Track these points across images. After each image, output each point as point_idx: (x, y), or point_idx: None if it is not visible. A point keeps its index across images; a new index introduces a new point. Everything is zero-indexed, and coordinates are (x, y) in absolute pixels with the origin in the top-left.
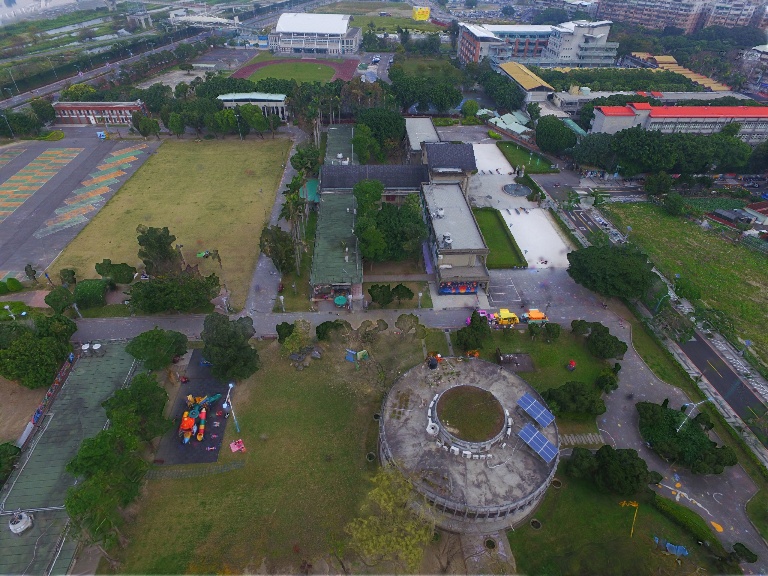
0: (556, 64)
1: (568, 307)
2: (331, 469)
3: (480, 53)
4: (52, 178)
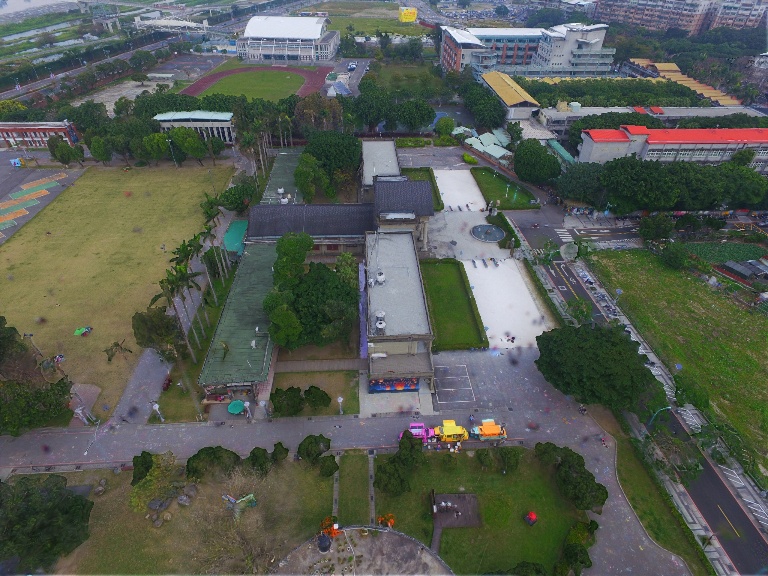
0: (546, 72)
1: (535, 412)
2: None
3: (462, 61)
4: None
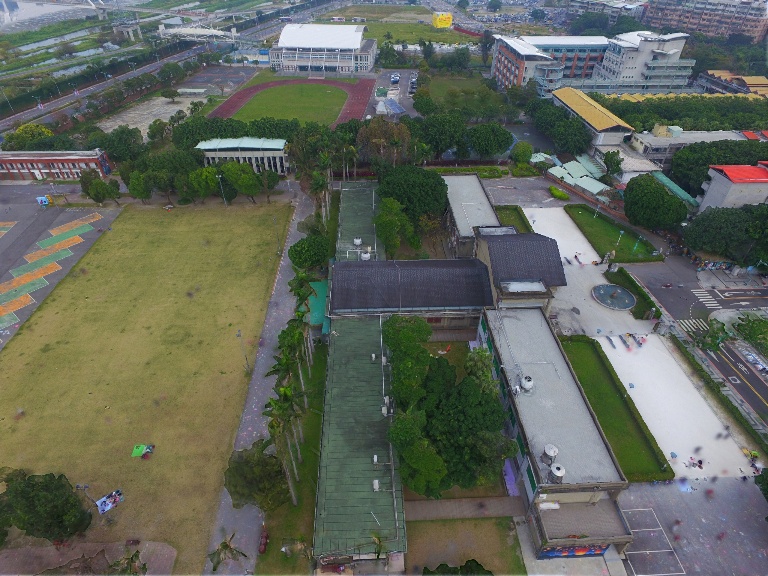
0: (616, 86)
1: None
2: None
3: (524, 74)
4: None
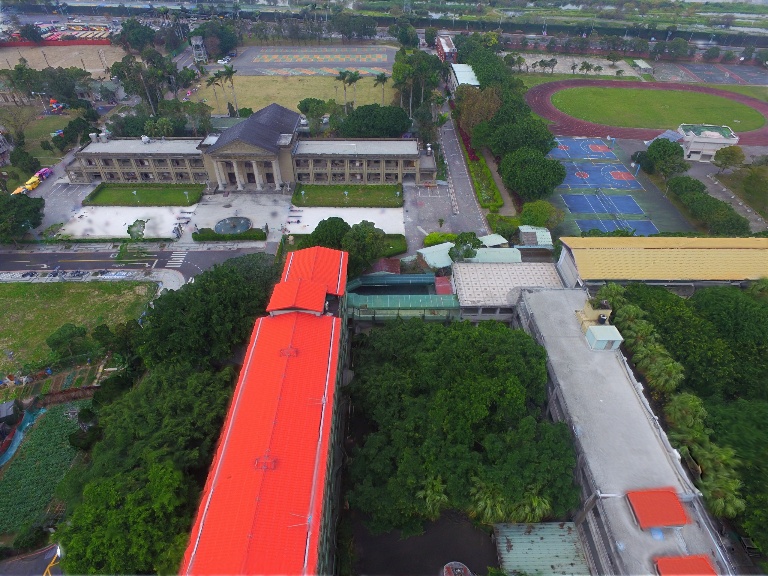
0: None
1: None
2: None
3: None
4: (334, 61)
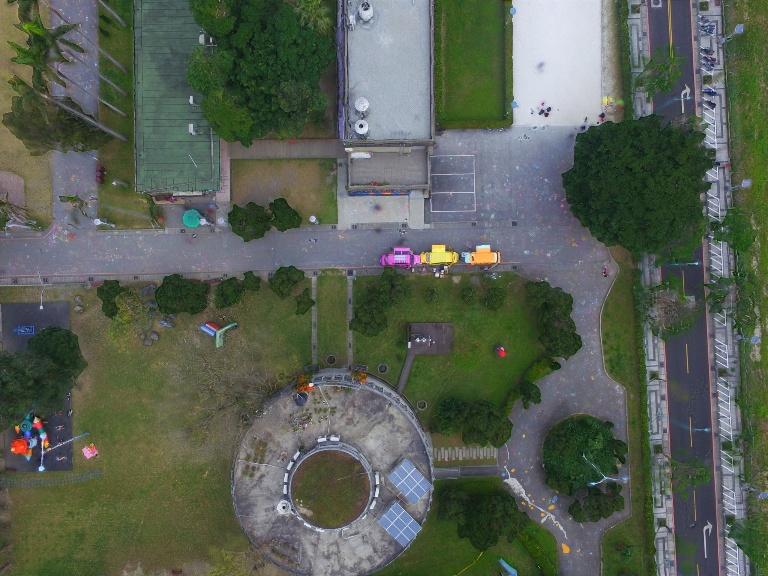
0: None
1: (542, 229)
2: (195, 481)
3: None
4: None
